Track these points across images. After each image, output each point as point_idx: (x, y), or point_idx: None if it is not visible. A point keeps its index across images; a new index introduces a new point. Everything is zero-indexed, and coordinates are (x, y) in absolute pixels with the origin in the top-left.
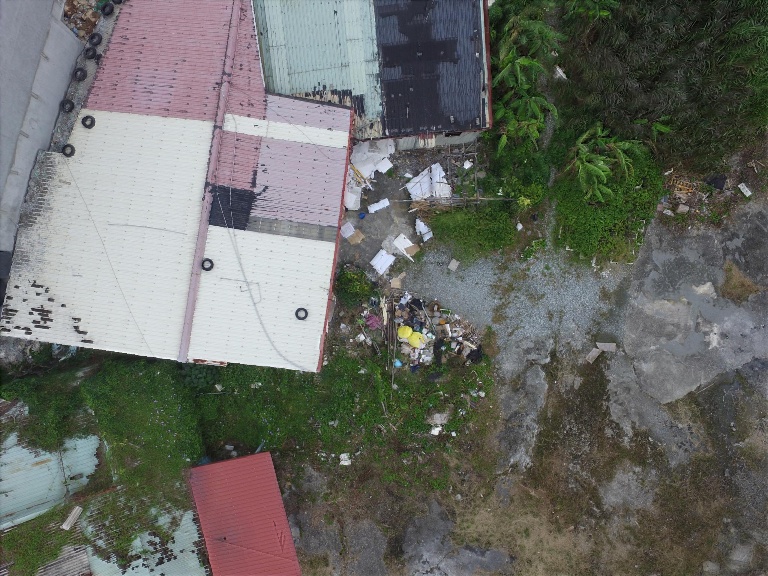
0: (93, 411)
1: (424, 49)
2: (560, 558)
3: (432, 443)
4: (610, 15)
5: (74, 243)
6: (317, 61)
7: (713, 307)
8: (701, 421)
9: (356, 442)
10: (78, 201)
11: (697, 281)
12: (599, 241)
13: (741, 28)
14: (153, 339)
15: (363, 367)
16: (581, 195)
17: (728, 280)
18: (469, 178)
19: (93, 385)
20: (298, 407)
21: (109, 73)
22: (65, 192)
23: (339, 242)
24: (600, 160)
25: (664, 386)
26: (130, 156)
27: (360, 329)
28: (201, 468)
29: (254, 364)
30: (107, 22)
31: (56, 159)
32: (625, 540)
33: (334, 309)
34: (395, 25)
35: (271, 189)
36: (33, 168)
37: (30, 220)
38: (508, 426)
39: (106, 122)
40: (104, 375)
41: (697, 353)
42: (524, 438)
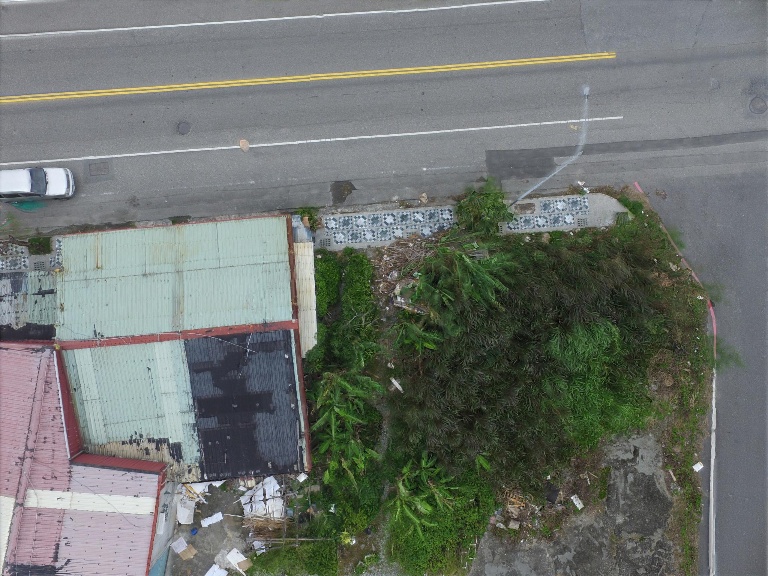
0: None
1: (239, 402)
2: None
3: None
4: (435, 348)
5: None
6: (133, 412)
7: None
8: None
9: None
10: None
11: None
12: (429, 560)
13: (557, 375)
14: None
15: None
16: None
17: None
18: (303, 491)
19: None
20: None
21: None
22: None
23: (171, 557)
24: (421, 498)
25: None
26: None
27: None
28: None
29: None
30: None
31: None
32: None
33: None
34: (209, 380)
35: (73, 562)
36: None
37: None
38: None
39: None
40: None
41: None
42: None
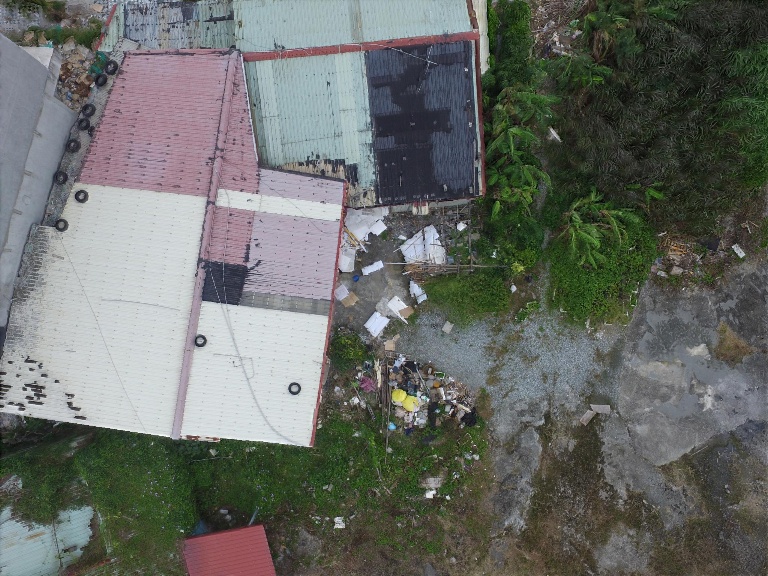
0: (87, 482)
1: (417, 119)
2: None
3: (426, 506)
4: (603, 80)
5: (67, 318)
6: (310, 131)
7: (707, 369)
8: (695, 483)
9: (350, 505)
10: (71, 276)
11: (691, 343)
12: (593, 304)
13: (734, 96)
14: (146, 416)
15: (357, 430)
16: (575, 258)
17: (722, 342)
18: (463, 240)
19: (87, 458)
20: (292, 471)
21: (102, 147)
22: (58, 267)
23: (333, 305)
24: (593, 226)
25: (658, 448)
26: (123, 231)
27: (354, 392)
28: (195, 540)
29: (247, 439)
30: (100, 93)
31: (49, 233)
32: None
33: (328, 372)
34: (388, 96)
35: (264, 263)
36: (26, 242)
37: (23, 295)
38: (502, 489)
39: (99, 196)
40: (98, 447)
41: (691, 415)
42: (518, 501)
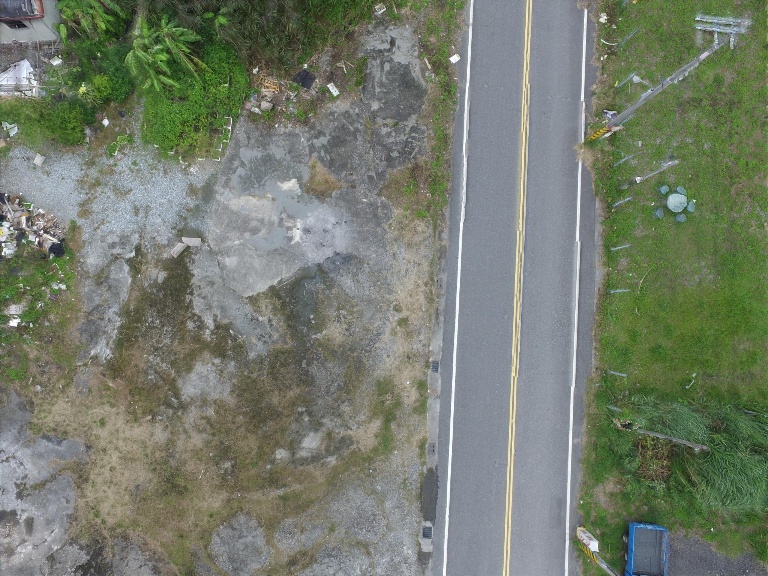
0: None
1: None
2: (136, 447)
3: (10, 334)
4: None
5: None
6: None
7: (297, 203)
8: (281, 314)
9: None
10: None
11: (282, 178)
12: (180, 136)
13: None
14: None
15: None
16: None
17: (312, 177)
18: (57, 74)
19: None
20: None
21: None
22: None
23: None
24: (156, 50)
25: (246, 280)
26: None
27: None
28: None
29: None
30: None
31: None
32: (201, 429)
33: None
34: None
35: None
36: None
37: None
38: (90, 318)
39: None
40: None
41: (279, 248)
42: (105, 330)
